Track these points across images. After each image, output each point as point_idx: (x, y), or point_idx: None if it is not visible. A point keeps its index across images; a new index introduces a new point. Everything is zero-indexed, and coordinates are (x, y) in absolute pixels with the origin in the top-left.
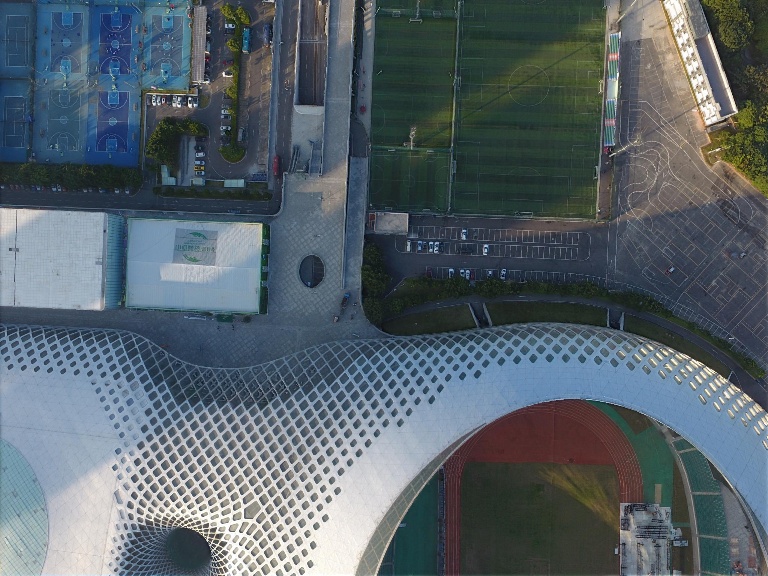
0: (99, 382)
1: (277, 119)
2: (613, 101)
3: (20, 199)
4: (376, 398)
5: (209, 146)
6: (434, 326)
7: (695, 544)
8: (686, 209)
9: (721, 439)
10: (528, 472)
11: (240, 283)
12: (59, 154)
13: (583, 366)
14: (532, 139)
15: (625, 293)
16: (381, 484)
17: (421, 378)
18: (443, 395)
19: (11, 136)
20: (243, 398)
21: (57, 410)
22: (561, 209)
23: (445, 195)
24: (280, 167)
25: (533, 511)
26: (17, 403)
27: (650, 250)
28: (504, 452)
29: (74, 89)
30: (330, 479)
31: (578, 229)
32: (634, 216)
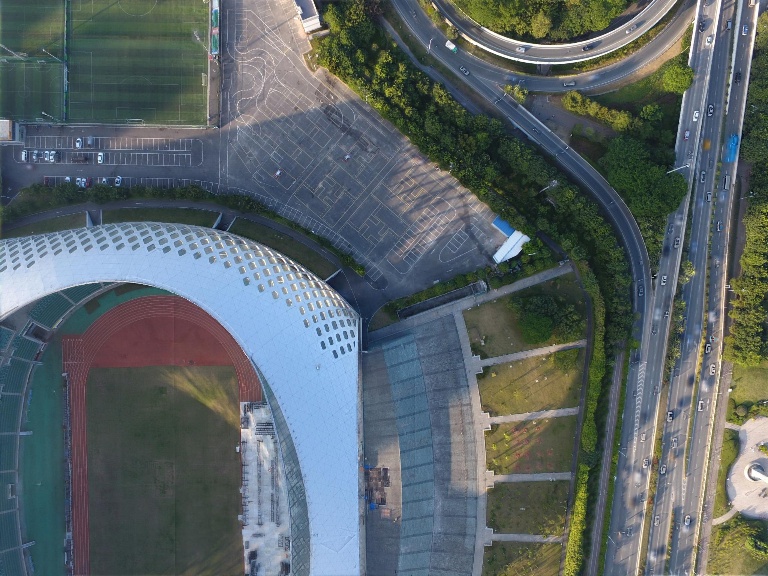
0: None
1: None
2: (217, 10)
3: None
4: None
5: None
6: None
7: None
8: (292, 114)
9: (250, 315)
10: (151, 376)
11: None
12: None
13: (132, 253)
14: (142, 48)
15: None
16: None
17: None
18: None
19: None
20: None
21: None
22: (173, 116)
23: (60, 105)
24: None
25: (157, 414)
26: None
27: (259, 155)
28: (126, 357)
29: None
30: None
31: (190, 136)
32: (243, 122)
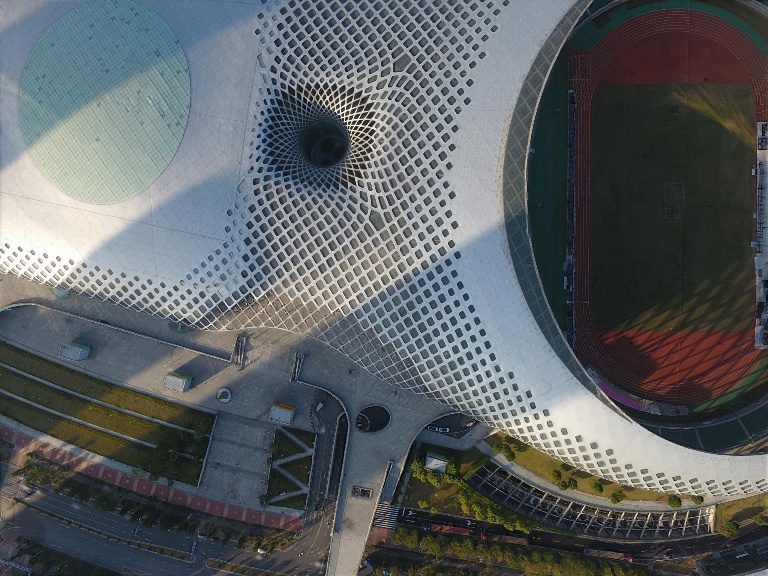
0: None
1: None
2: None
3: None
4: None
5: None
6: None
7: None
8: None
9: None
10: (661, 94)
11: None
12: None
13: None
14: None
15: None
16: (542, 12)
17: None
18: None
19: None
20: None
21: None
22: None
23: None
24: None
25: (666, 134)
26: None
27: None
28: (637, 74)
29: None
30: (485, 21)
31: None
32: None
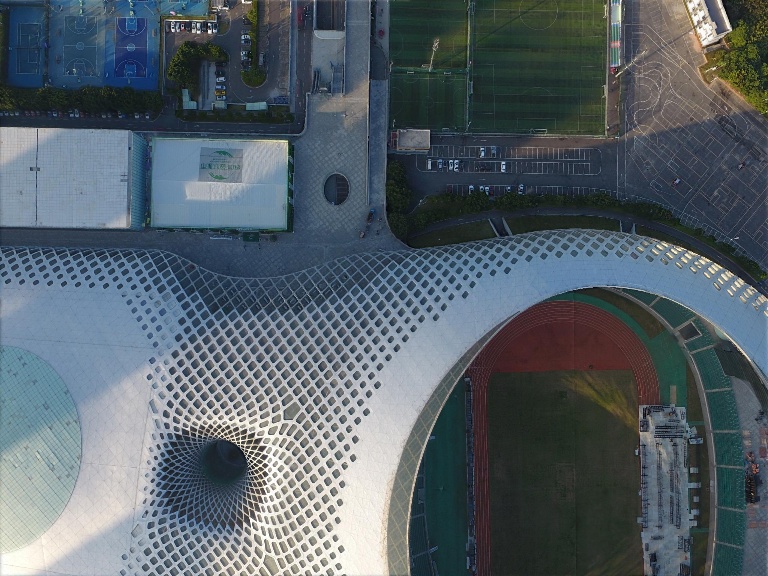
0: (130, 294)
1: (297, 44)
2: (617, 24)
3: (36, 125)
4: (410, 297)
5: (229, 71)
6: (457, 240)
7: (709, 441)
8: (688, 125)
9: (737, 319)
10: (551, 380)
11: (267, 200)
12: (76, 80)
13: (606, 259)
14: (543, 61)
15: (636, 203)
16: (421, 374)
17: (453, 277)
18: (476, 290)
19: (25, 63)
20: (277, 305)
21: (87, 322)
22: (573, 127)
23: (463, 115)
24: (302, 90)
25: (557, 418)
26: (45, 317)
27: (656, 164)
28: (527, 362)
29: (91, 16)
30: (369, 375)
31: (589, 145)
32: (640, 132)
